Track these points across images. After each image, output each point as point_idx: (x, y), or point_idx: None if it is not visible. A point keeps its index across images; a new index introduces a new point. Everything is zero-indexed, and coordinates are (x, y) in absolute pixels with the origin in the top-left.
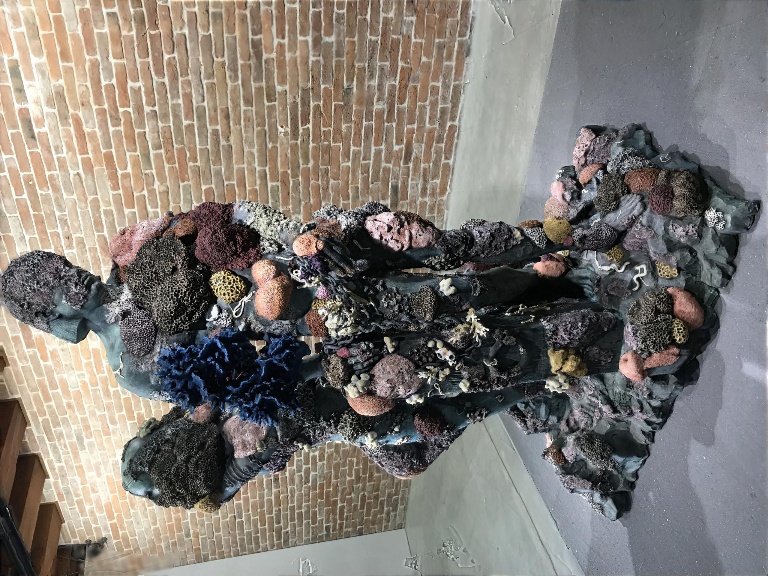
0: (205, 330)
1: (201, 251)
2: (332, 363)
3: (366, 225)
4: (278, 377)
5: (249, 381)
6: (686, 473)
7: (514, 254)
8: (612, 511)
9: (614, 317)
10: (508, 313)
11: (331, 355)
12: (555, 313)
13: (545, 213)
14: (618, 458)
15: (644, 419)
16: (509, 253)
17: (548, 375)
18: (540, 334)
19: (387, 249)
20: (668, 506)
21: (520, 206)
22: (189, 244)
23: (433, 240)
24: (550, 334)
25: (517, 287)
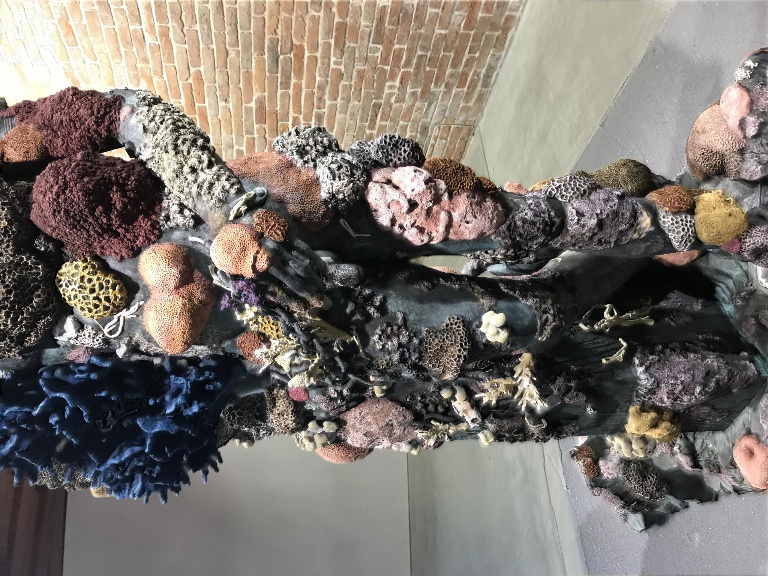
0: (57, 348)
1: (39, 219)
2: (278, 407)
3: (369, 194)
4: (177, 445)
5: (122, 461)
6: (763, 562)
7: (627, 251)
8: (638, 524)
9: (755, 373)
10: (585, 325)
11: (279, 389)
12: (661, 346)
13: (694, 131)
14: (673, 498)
15: (733, 484)
16: (619, 249)
17: (618, 430)
18: (627, 387)
19: (401, 239)
20: (717, 567)
21: (645, 53)
22: (35, 174)
23: (490, 229)
24: (644, 391)
25: (612, 288)
